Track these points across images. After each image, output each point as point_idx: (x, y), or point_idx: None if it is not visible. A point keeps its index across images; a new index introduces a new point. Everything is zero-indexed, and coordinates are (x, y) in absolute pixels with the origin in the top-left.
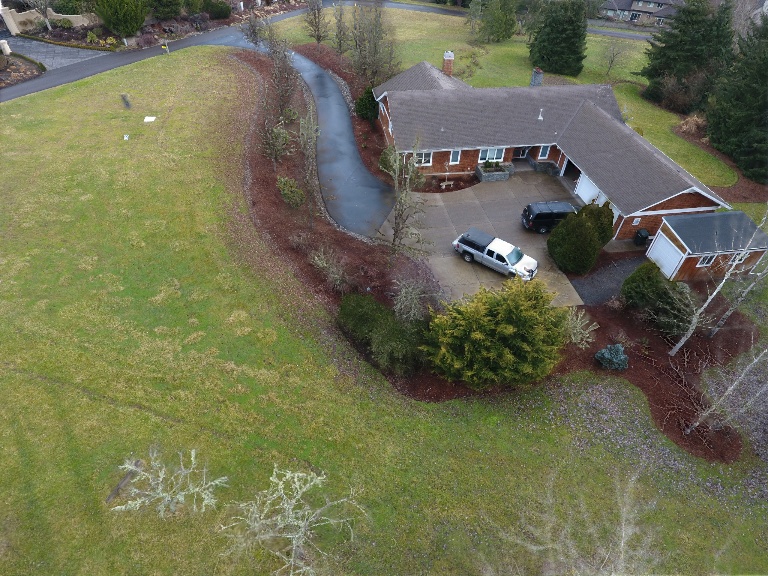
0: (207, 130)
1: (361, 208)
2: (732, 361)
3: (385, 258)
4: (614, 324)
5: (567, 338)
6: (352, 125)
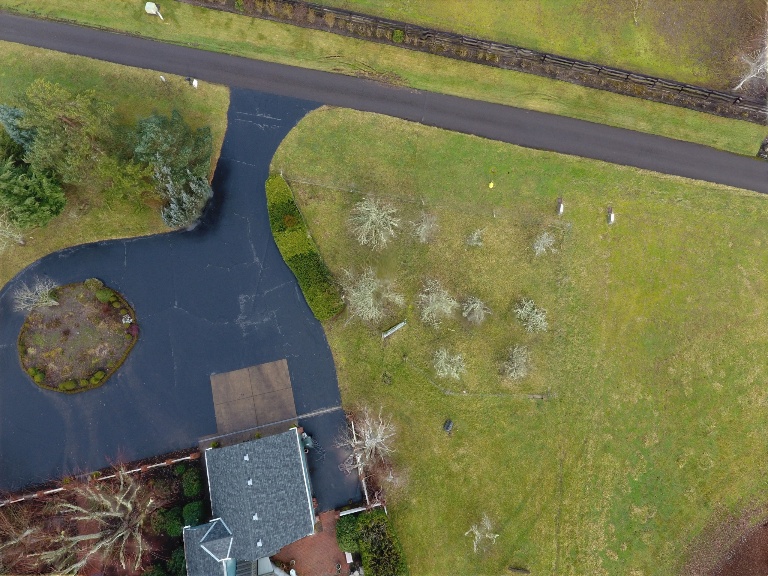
0: None
1: None
2: None
3: None
4: None
5: None
6: None
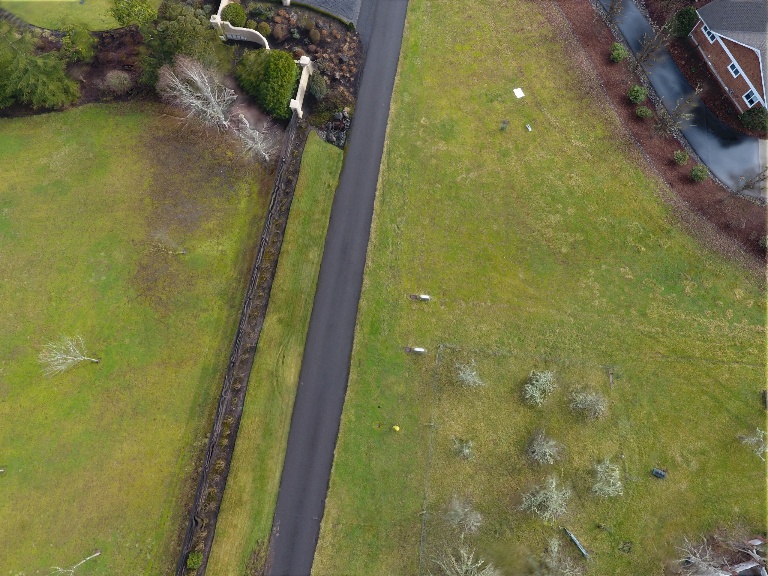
0: (574, 97)
1: (738, 168)
2: None
3: None
4: None
5: None
6: (666, 48)
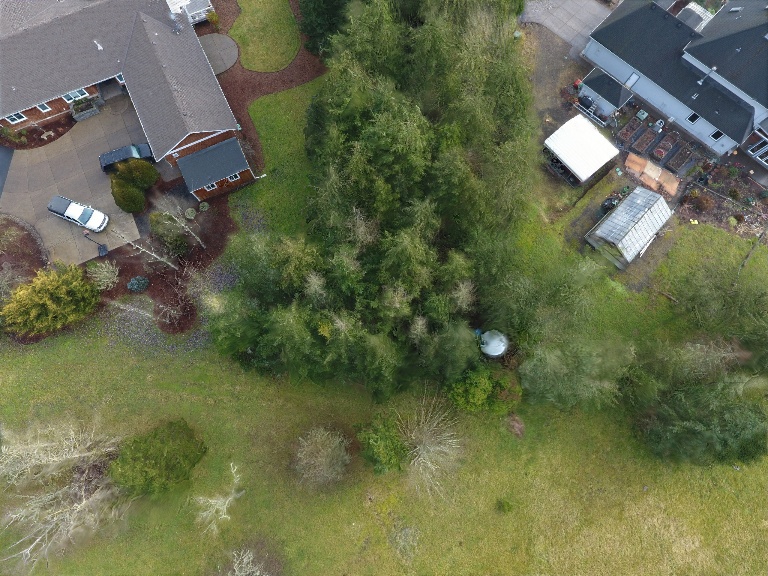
0: None
1: None
2: (211, 263)
3: (4, 234)
4: (152, 252)
5: (96, 289)
6: None
